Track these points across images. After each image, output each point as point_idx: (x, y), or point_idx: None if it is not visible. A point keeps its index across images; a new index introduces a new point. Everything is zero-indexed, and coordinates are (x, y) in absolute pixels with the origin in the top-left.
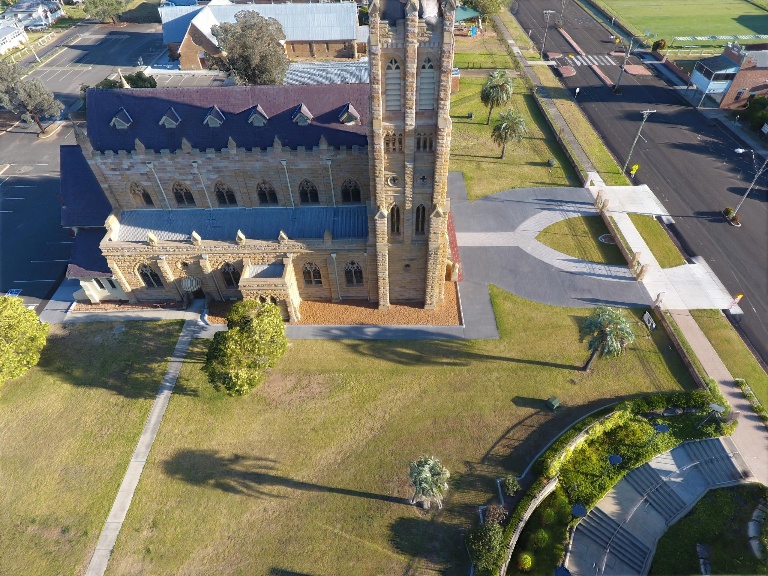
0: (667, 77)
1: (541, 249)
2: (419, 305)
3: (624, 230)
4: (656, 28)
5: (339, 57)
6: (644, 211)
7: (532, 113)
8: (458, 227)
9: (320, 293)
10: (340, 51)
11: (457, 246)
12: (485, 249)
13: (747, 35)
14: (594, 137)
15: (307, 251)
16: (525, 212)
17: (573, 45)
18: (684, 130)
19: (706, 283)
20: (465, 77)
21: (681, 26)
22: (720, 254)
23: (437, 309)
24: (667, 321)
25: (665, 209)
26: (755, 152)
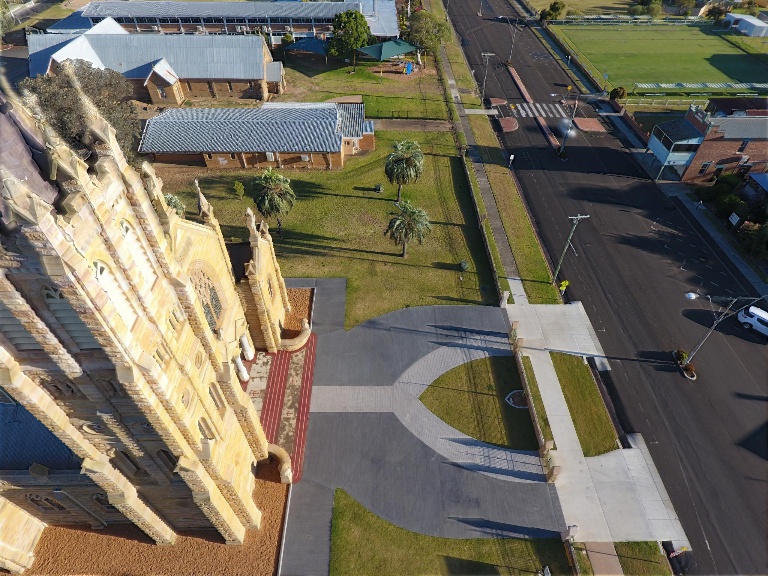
0: (624, 135)
1: (423, 418)
2: (220, 536)
3: (542, 383)
4: (618, 68)
5: (245, 98)
6: (572, 348)
7: (456, 185)
8: (318, 376)
9: (71, 518)
10: (246, 91)
11: (308, 412)
12: (346, 418)
13: (718, 83)
14: (525, 223)
15: (14, 487)
16: (415, 349)
17: (521, 89)
18: (636, 215)
19: (643, 487)
20: (386, 130)
21: (646, 66)
22: (666, 430)
23: (246, 543)
24: (579, 575)
25: (600, 345)
26: (720, 250)
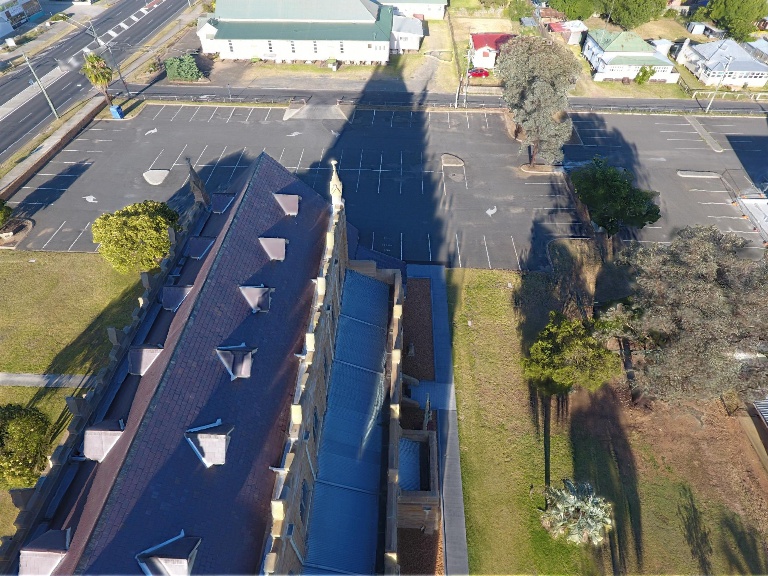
0: None
1: None
2: None
3: None
4: None
5: None
6: None
7: None
8: None
9: None
10: None
11: None
12: None
13: None
14: None
15: None
16: None
17: None
18: None
19: None
20: None
21: None
22: None
23: None
24: None
25: None
26: None
